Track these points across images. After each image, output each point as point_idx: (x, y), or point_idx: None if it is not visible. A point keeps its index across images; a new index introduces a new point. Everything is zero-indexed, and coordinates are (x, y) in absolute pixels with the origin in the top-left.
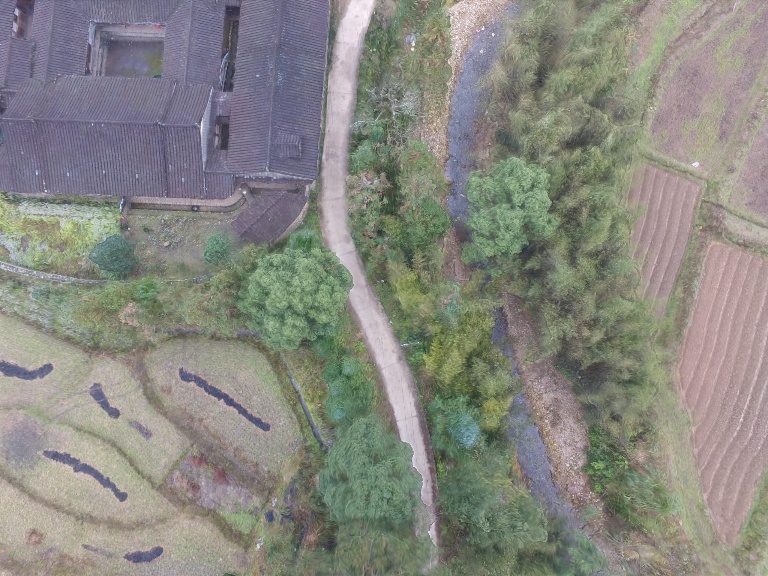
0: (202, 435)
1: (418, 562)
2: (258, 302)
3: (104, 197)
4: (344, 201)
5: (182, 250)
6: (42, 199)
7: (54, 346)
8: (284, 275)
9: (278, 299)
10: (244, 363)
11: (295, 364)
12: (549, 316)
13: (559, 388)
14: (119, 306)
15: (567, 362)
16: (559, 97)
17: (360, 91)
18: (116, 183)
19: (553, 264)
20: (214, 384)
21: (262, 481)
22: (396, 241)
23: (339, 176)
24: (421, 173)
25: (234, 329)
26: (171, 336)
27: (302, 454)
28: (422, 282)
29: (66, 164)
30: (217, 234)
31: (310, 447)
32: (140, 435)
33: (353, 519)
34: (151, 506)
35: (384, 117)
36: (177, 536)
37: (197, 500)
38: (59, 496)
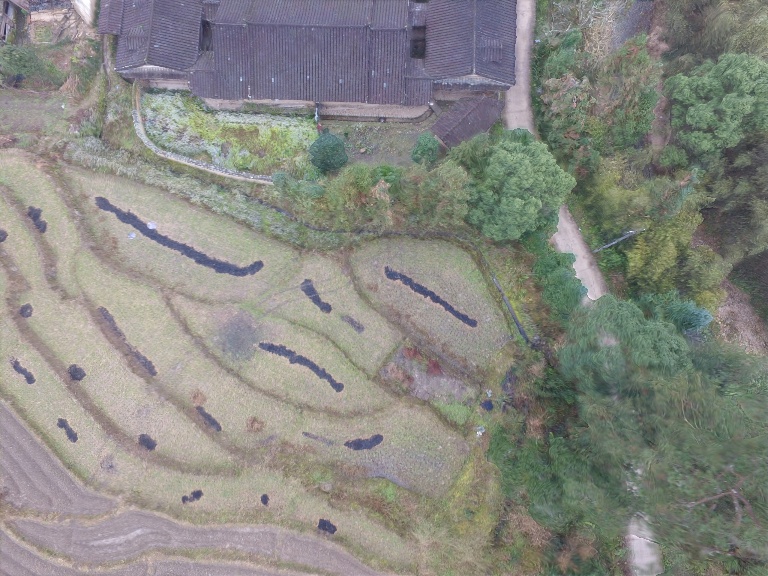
0: (410, 331)
1: (729, 400)
2: (498, 183)
3: (294, 109)
4: (528, 113)
5: (377, 157)
6: (234, 111)
7: (264, 244)
8: (523, 157)
9: (526, 176)
10: (449, 262)
11: (500, 262)
12: (762, 210)
13: (735, 302)
14: (367, 184)
15: (747, 274)
16: (760, 1)
17: (538, 9)
18: (319, 88)
19: (767, 158)
20: (420, 282)
21: (471, 375)
22: (597, 143)
23: (521, 90)
24: (640, 67)
25: (460, 217)
26: (375, 236)
27: (514, 347)
28: (626, 182)
29: (272, 69)
30: (425, 134)
31: (517, 343)
32: (352, 329)
33: (648, 366)
34: (367, 396)
35: (575, 27)
36: (396, 424)
37: (411, 392)
38: (276, 386)
